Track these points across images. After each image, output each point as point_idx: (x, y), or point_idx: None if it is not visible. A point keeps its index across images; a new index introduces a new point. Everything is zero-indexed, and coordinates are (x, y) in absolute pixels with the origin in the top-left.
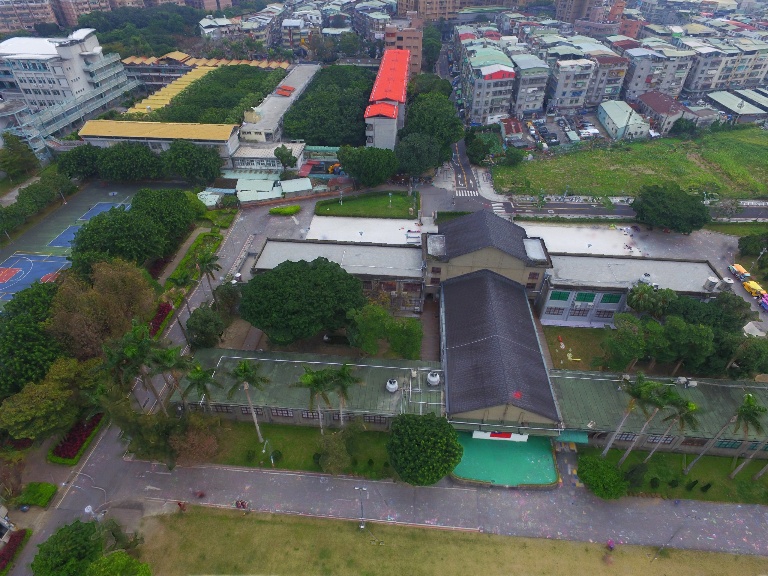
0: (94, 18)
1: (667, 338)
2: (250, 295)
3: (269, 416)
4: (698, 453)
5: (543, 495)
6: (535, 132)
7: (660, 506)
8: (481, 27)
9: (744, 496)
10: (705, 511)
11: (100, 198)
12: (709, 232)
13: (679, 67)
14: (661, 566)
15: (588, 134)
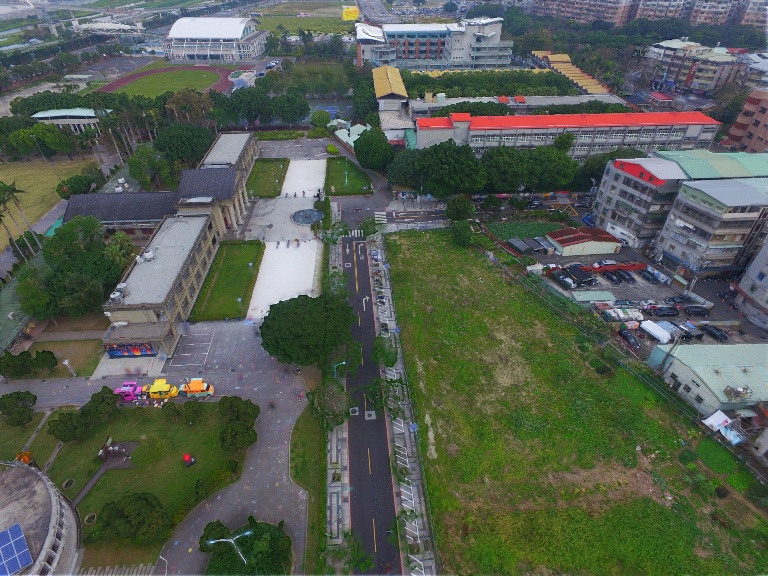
0: (632, 23)
1: None
2: None
3: None
4: None
5: None
6: (598, 267)
7: None
8: None
9: None
10: None
11: (343, 105)
12: (305, 400)
13: None
14: None
15: (620, 316)
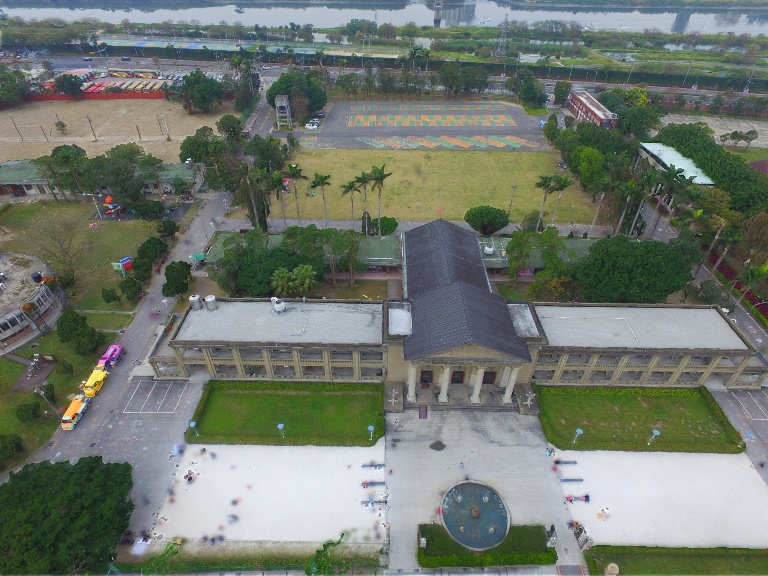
0: None
1: None
2: None
3: None
4: None
5: None
6: None
7: None
8: None
9: None
10: None
11: None
12: None
13: None
14: None
15: None
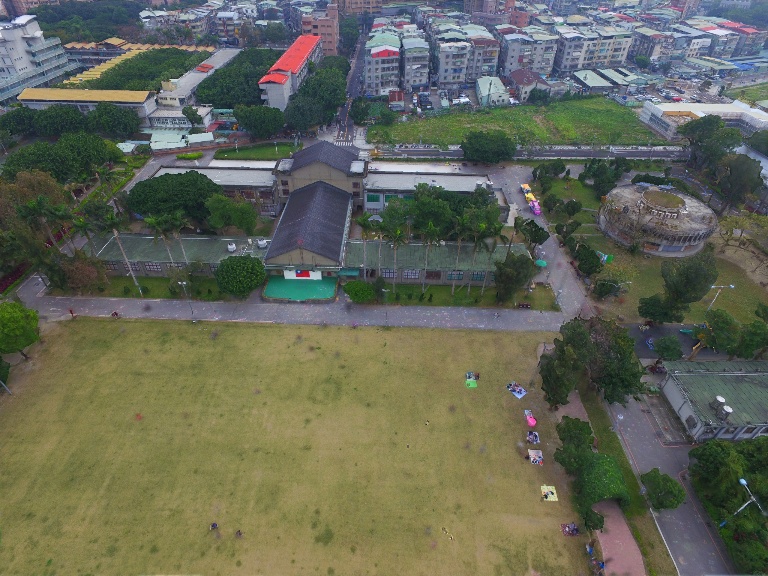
0: (42, 10)
1: (418, 209)
2: (133, 191)
3: (144, 271)
4: (438, 284)
5: (322, 306)
6: (417, 101)
7: (398, 309)
8: (397, 19)
9: (456, 303)
10: (426, 310)
11: None
12: (521, 166)
13: (546, 49)
14: (383, 334)
15: (458, 102)
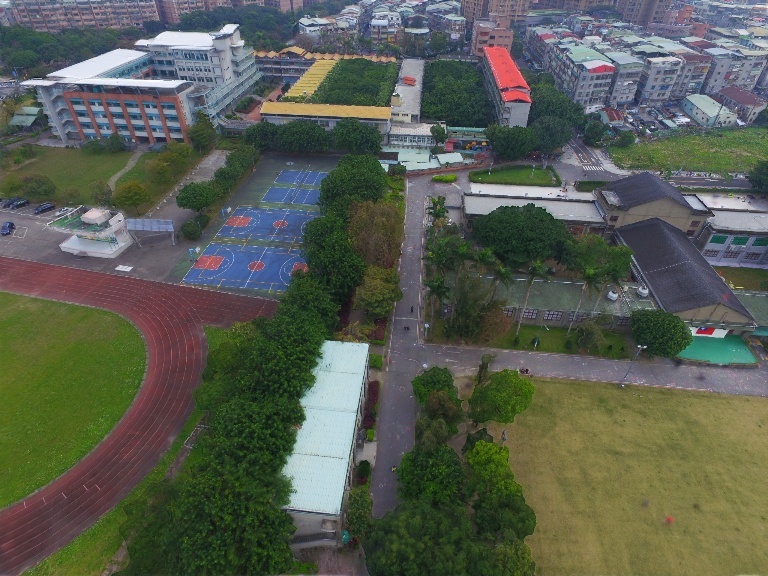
0: (197, 17)
1: None
2: (492, 227)
3: (517, 318)
4: None
5: (749, 371)
6: (632, 120)
7: None
8: (554, 29)
9: None
10: None
11: (281, 167)
12: None
13: (755, 65)
14: None
15: (682, 122)
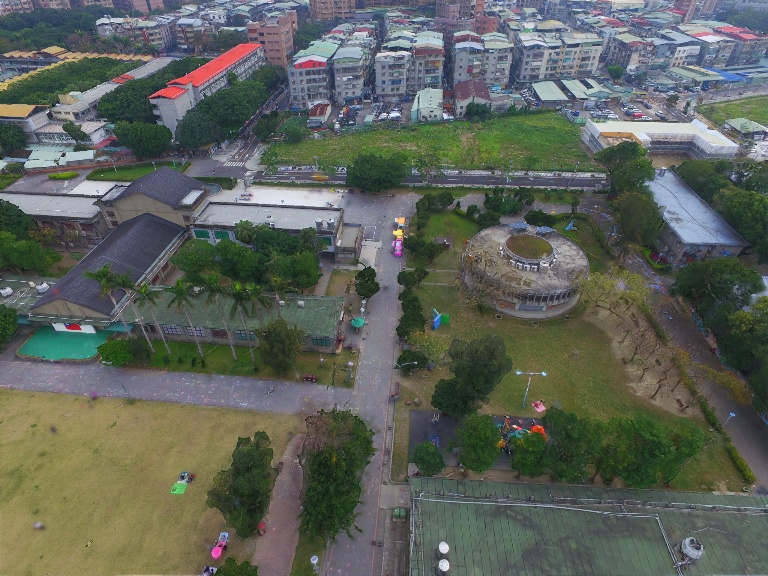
0: (10, 18)
1: (212, 255)
2: None
3: None
4: (228, 344)
5: (78, 367)
6: None
7: (161, 375)
8: None
9: (233, 371)
10: (192, 379)
11: None
12: (414, 195)
13: (499, 58)
14: (121, 409)
15: (385, 117)
